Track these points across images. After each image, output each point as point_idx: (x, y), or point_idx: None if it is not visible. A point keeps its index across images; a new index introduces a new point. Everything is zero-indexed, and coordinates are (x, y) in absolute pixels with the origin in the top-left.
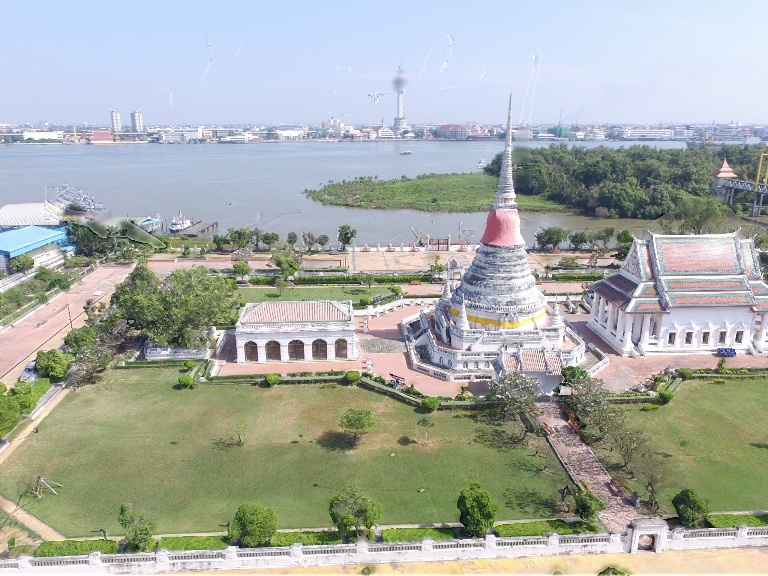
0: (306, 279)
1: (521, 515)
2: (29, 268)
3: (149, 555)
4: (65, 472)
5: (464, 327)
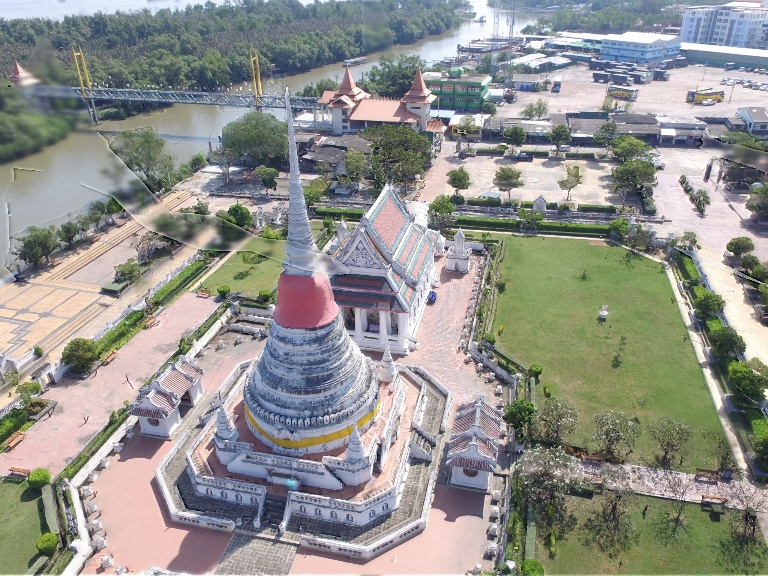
0: None
1: None
2: None
3: None
4: None
5: (365, 452)
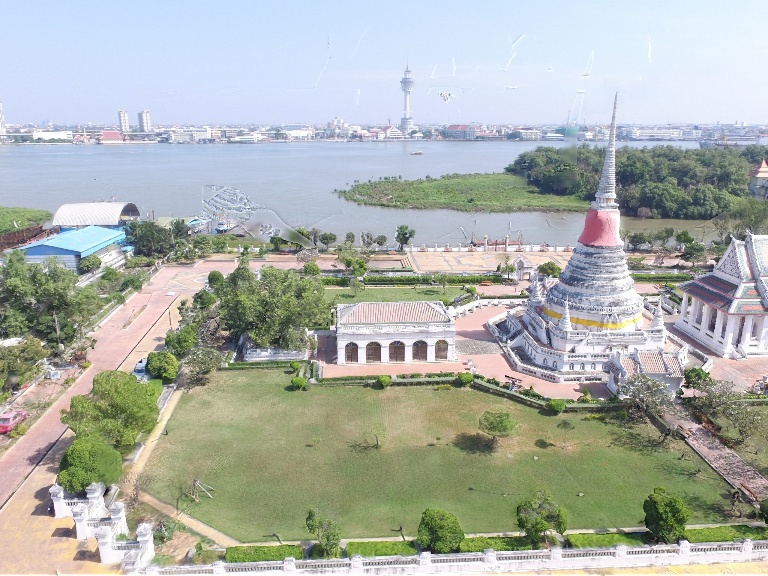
0: (376, 279)
1: (693, 520)
2: (97, 268)
3: (344, 561)
4: (211, 475)
5: (568, 328)
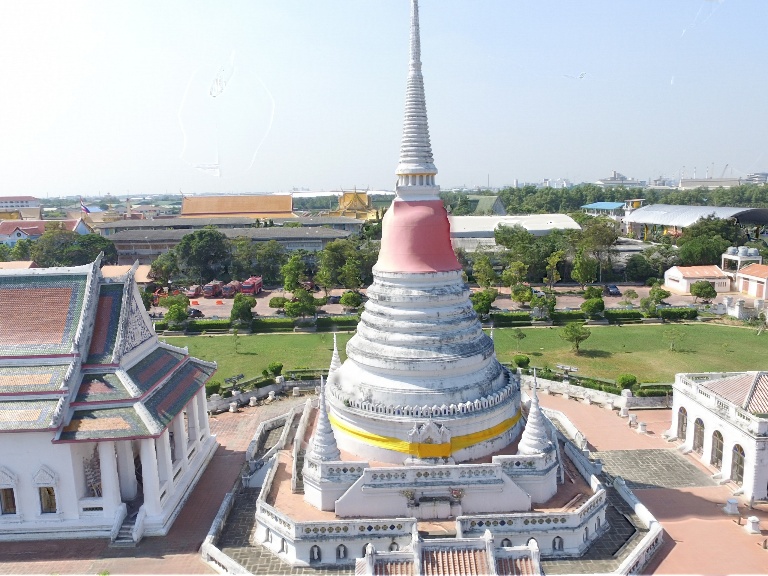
0: None
1: None
2: None
3: None
4: None
5: None
